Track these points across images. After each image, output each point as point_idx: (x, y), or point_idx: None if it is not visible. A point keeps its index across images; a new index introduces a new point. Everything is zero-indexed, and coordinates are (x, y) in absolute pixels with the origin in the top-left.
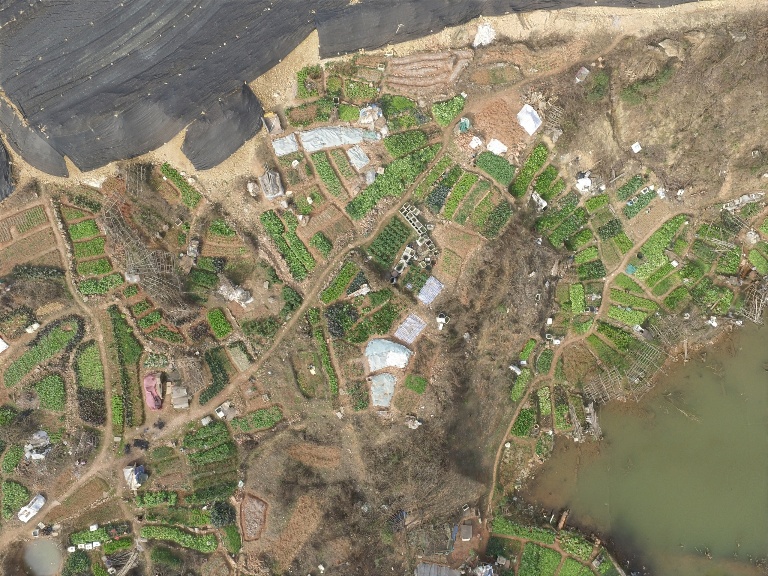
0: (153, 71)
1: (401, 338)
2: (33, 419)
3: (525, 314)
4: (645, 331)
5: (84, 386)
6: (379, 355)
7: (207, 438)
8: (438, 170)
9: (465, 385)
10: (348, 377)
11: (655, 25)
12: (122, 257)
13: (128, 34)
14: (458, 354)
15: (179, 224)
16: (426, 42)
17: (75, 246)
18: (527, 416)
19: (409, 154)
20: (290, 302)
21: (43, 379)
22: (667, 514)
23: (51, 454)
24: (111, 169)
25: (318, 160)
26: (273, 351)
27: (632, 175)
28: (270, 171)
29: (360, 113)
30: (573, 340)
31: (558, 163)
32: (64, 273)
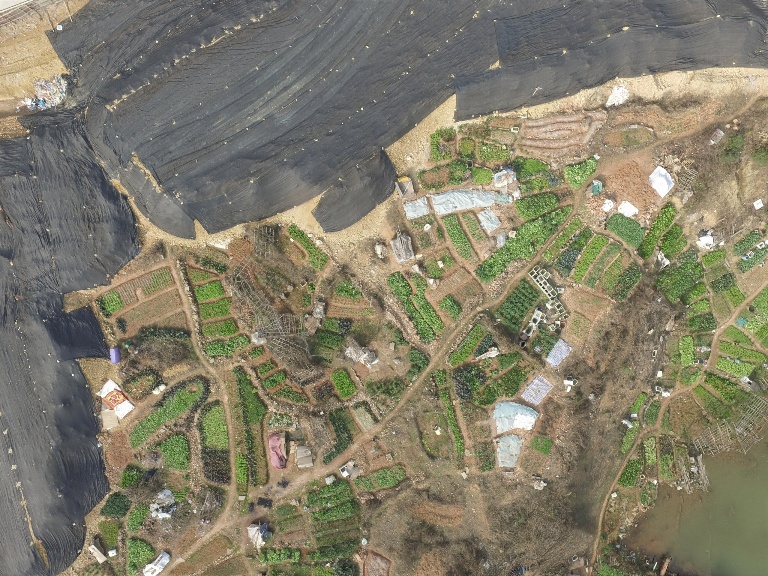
0: (289, 136)
1: (528, 400)
2: (158, 478)
3: (642, 371)
4: (753, 383)
5: (208, 446)
6: (507, 417)
7: (330, 496)
8: (568, 232)
9: (584, 442)
10: (476, 439)
11: None
12: (249, 319)
13: (263, 98)
14: (583, 415)
15: (304, 285)
16: (560, 104)
17: (201, 307)
18: (635, 467)
19: (540, 217)
20: (418, 364)
21: (167, 439)
22: (766, 560)
23: (177, 513)
24: (237, 230)
25: (449, 223)
26: (398, 411)
27: (750, 230)
28: (402, 235)
29: (494, 177)
30: (680, 391)
31: (682, 222)
32: (190, 334)
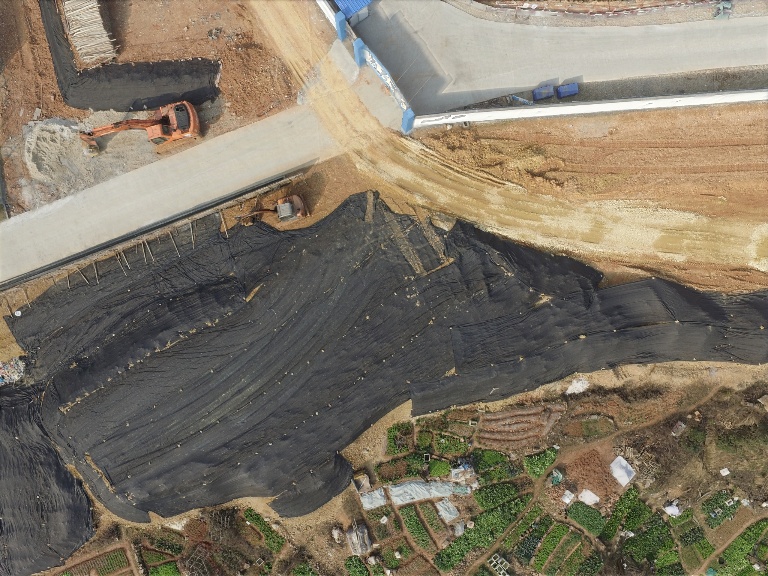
0: (243, 439)
1: None
2: None
3: None
4: None
5: None
6: None
7: None
8: (528, 520)
9: None
10: None
11: (754, 379)
12: None
13: (217, 400)
14: None
15: (261, 564)
16: (519, 397)
17: None
18: None
19: (499, 506)
20: None
21: None
22: None
23: None
24: (193, 513)
25: (407, 515)
26: None
27: (717, 490)
28: (358, 529)
29: (452, 473)
30: None
31: (646, 495)
32: None
